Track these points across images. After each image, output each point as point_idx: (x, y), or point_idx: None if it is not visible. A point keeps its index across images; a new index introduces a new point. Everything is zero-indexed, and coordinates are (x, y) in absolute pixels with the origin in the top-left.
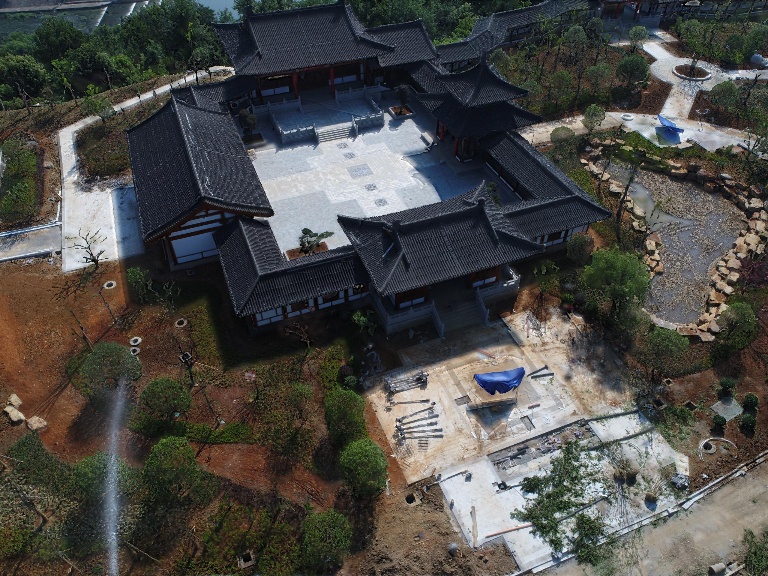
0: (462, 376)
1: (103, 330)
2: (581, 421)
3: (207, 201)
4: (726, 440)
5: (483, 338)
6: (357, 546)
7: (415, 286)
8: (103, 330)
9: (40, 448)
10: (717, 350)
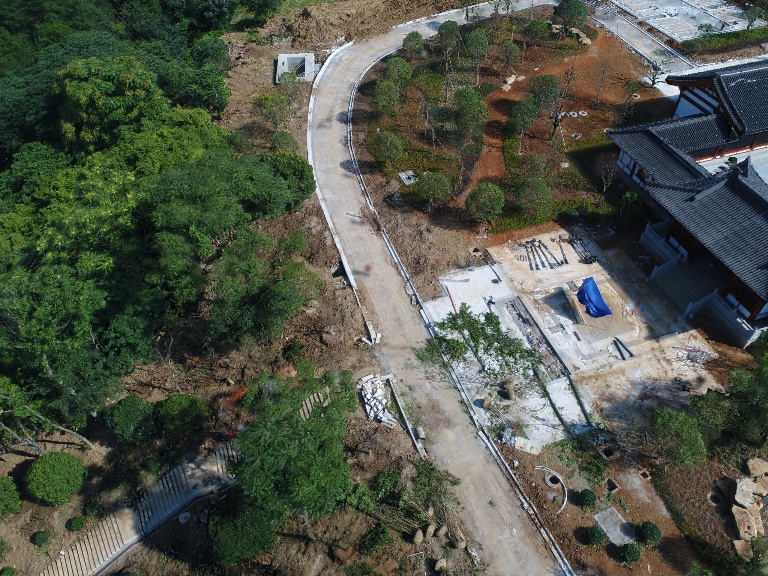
0: (602, 288)
1: (587, 98)
2: (567, 370)
3: (716, 81)
4: (565, 502)
5: (658, 309)
6: (438, 220)
7: (670, 209)
8: (587, 98)
9: (489, 91)
10: (721, 555)
